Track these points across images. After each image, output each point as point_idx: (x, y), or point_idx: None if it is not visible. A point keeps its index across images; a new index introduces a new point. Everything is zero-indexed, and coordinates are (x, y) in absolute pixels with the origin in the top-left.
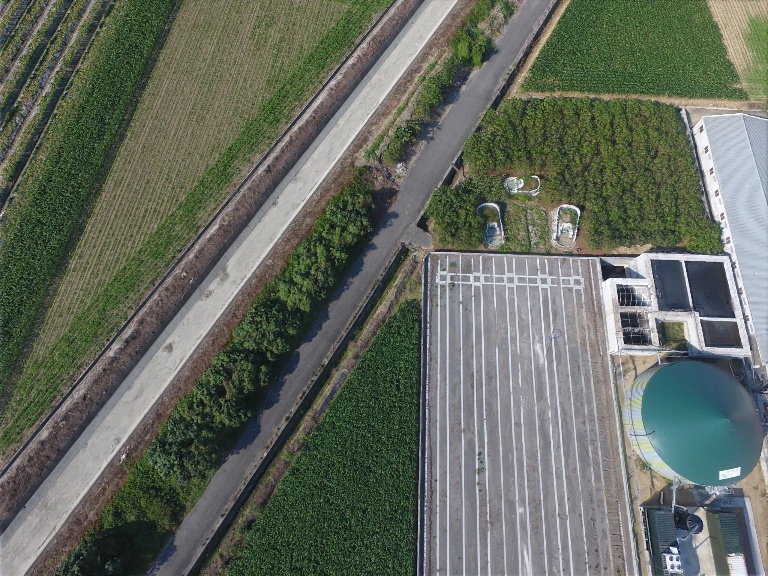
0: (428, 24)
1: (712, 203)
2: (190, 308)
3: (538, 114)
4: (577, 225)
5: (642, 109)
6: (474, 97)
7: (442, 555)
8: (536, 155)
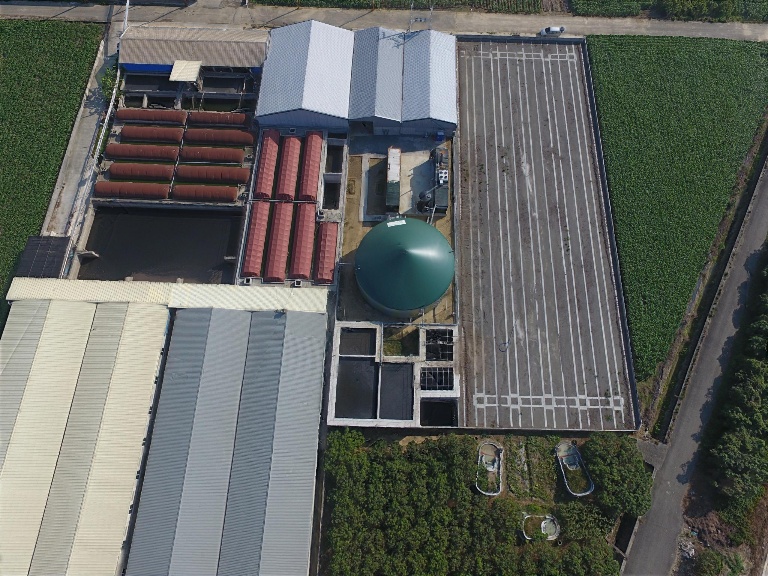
0: None
1: None
2: None
3: None
4: None
5: None
6: None
7: (589, 189)
8: (533, 569)
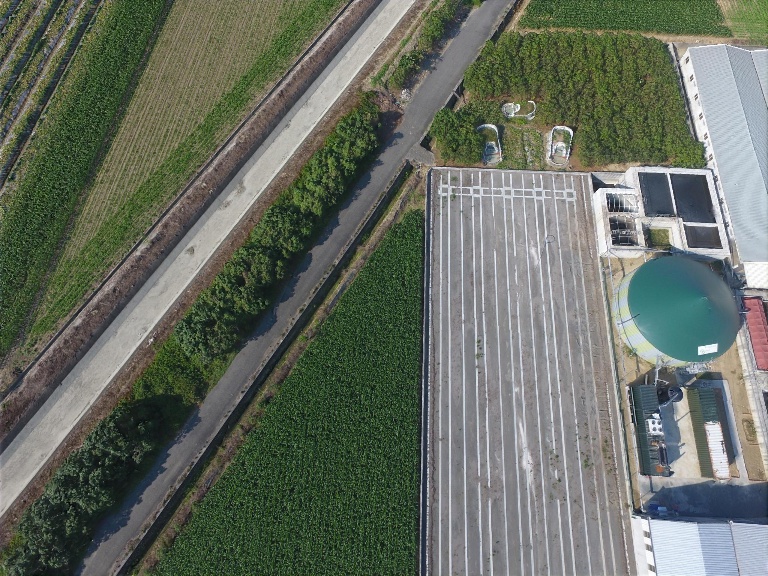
0: None
1: (697, 126)
2: (210, 216)
3: (534, 45)
4: (570, 145)
5: (632, 41)
6: (474, 32)
7: (444, 427)
8: (532, 81)
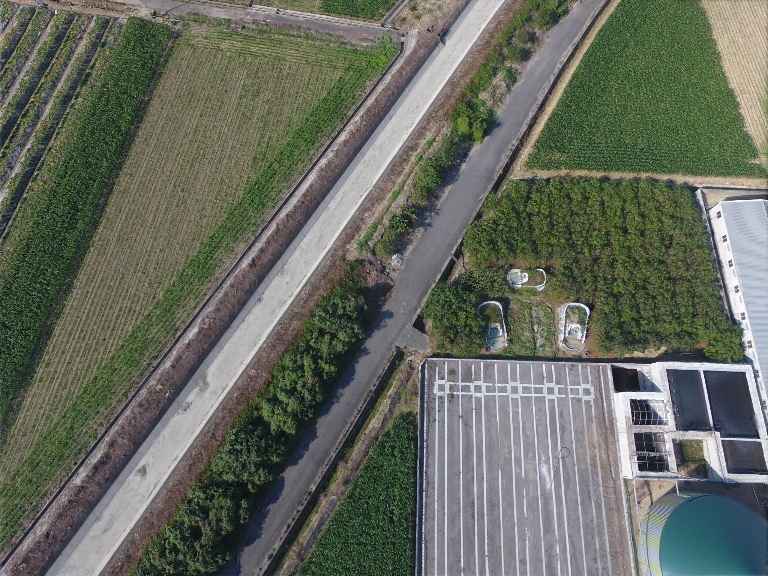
0: (426, 92)
1: (731, 299)
2: (166, 424)
3: (543, 199)
4: (586, 325)
5: (655, 192)
6: (475, 177)
7: None
8: (542, 247)
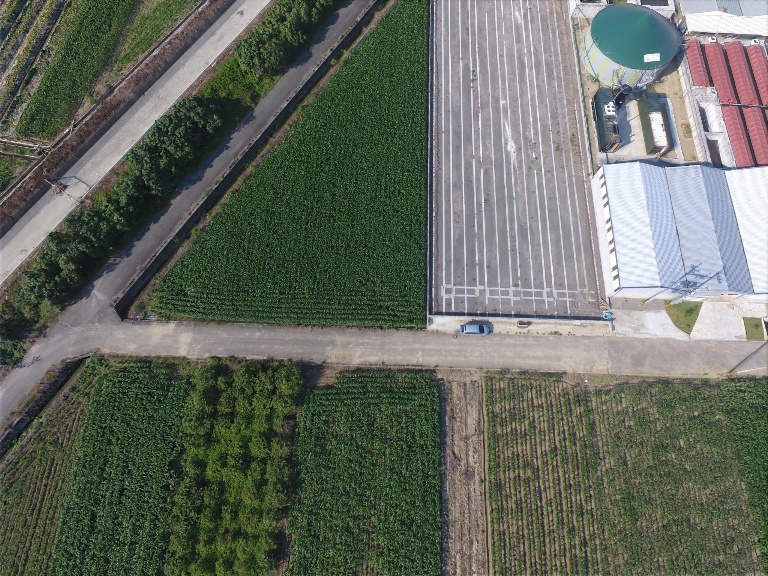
0: None
1: None
2: None
3: None
4: None
5: None
6: None
7: (446, 124)
8: None
